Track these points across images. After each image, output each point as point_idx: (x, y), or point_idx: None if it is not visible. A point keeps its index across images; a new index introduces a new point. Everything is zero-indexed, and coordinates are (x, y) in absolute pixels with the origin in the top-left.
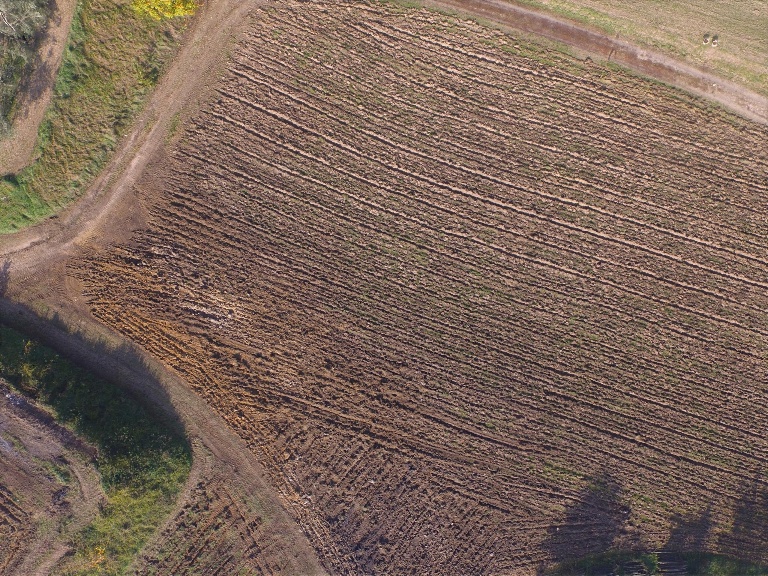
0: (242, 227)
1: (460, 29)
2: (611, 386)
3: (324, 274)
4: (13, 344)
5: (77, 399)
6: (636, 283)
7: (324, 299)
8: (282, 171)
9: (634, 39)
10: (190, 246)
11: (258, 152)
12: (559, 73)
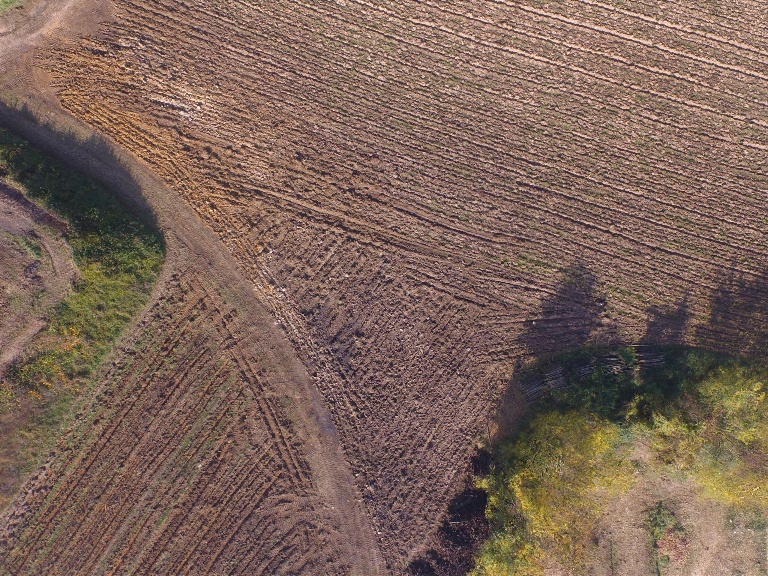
0: (209, 19)
1: None
2: (584, 176)
3: (292, 66)
4: None
5: (47, 181)
6: (607, 70)
7: (293, 91)
8: None
9: None
10: (157, 38)
11: None
12: None
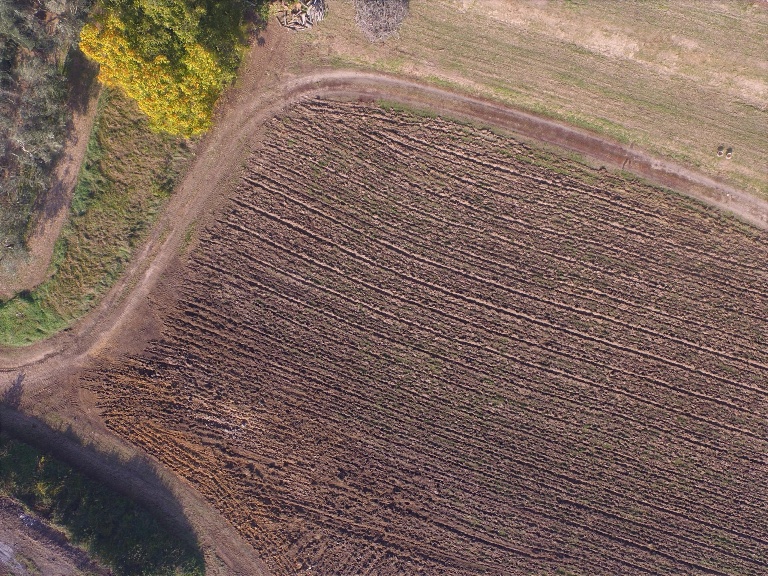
0: (256, 336)
1: (475, 138)
2: (624, 494)
3: (338, 383)
4: (27, 460)
5: (90, 516)
6: (649, 392)
7: (337, 408)
8: (296, 280)
9: (648, 149)
10: (204, 356)
11: (272, 261)
12: (573, 182)
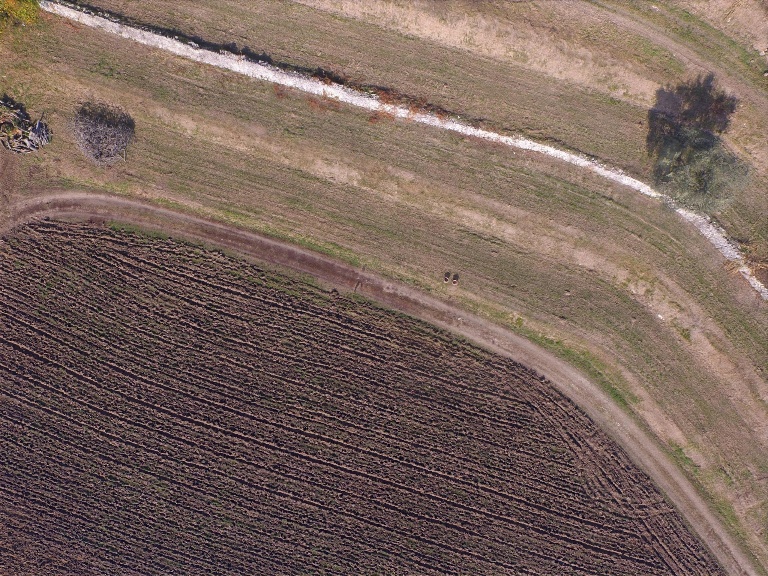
0: None
1: (206, 260)
2: None
3: (62, 505)
4: None
5: None
6: (379, 515)
7: (62, 530)
8: (22, 401)
9: (380, 272)
10: None
11: None
12: (305, 305)
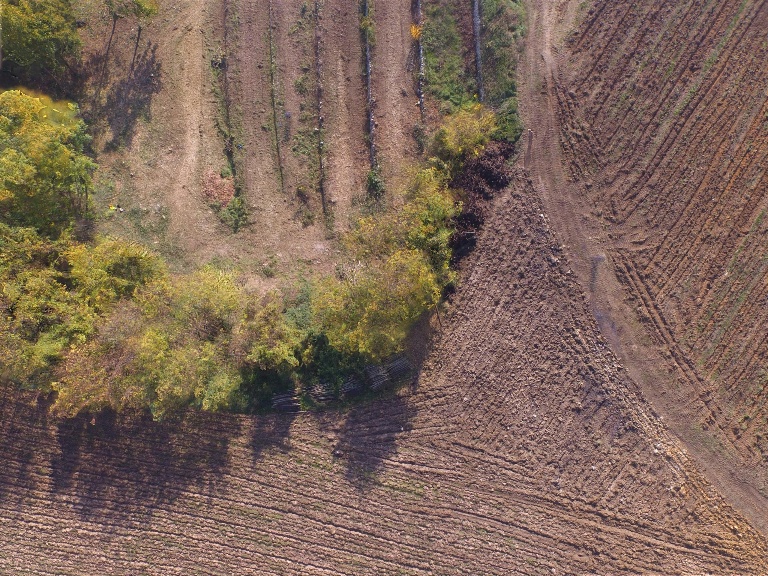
0: None
1: None
2: None
3: None
4: None
5: None
6: None
7: None
8: None
9: None
10: None
11: None
12: None
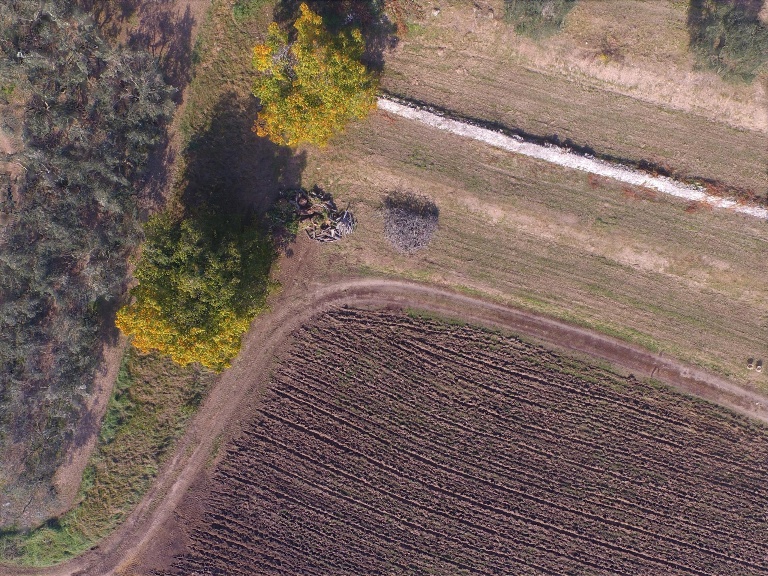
0: (282, 548)
1: (503, 346)
2: None
3: None
4: None
5: None
6: None
7: None
8: (323, 491)
9: (677, 357)
10: (230, 570)
11: (299, 472)
12: (602, 390)
